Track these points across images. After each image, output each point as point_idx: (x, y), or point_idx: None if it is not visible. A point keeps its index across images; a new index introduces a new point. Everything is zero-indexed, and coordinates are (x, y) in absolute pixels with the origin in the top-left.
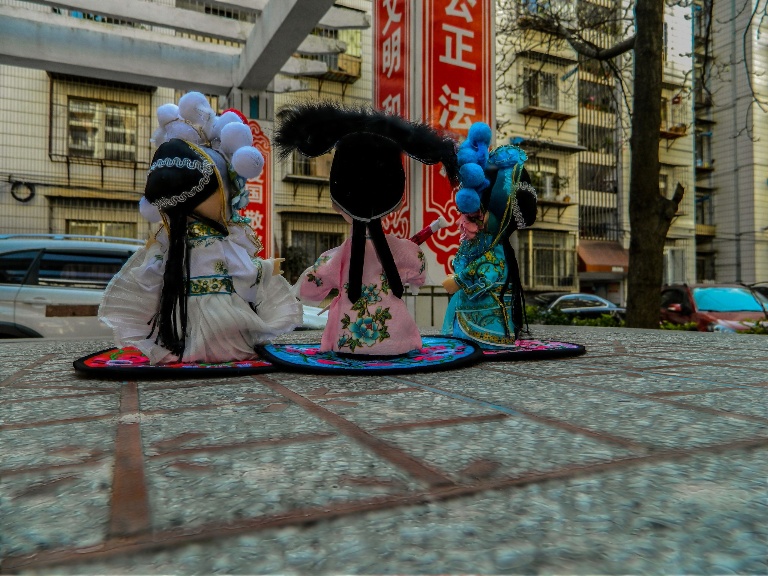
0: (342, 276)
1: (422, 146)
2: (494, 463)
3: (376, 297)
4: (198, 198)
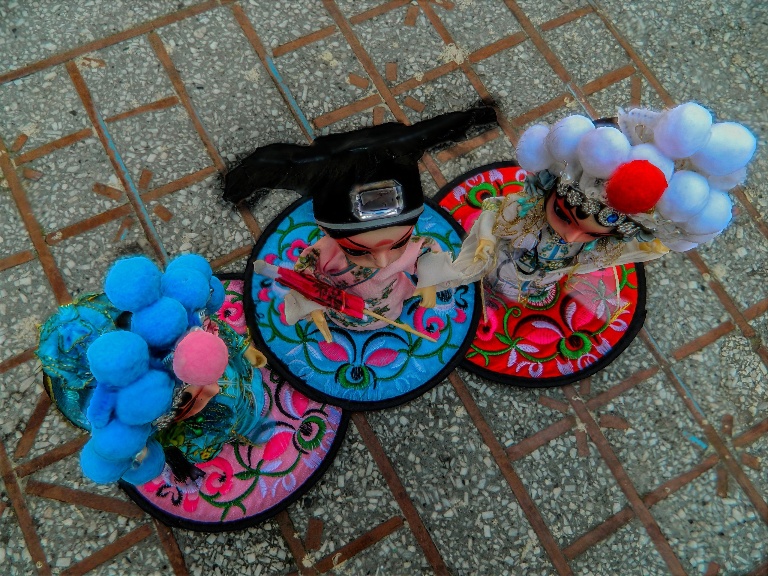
0: None
1: (282, 150)
2: None
3: None
4: None
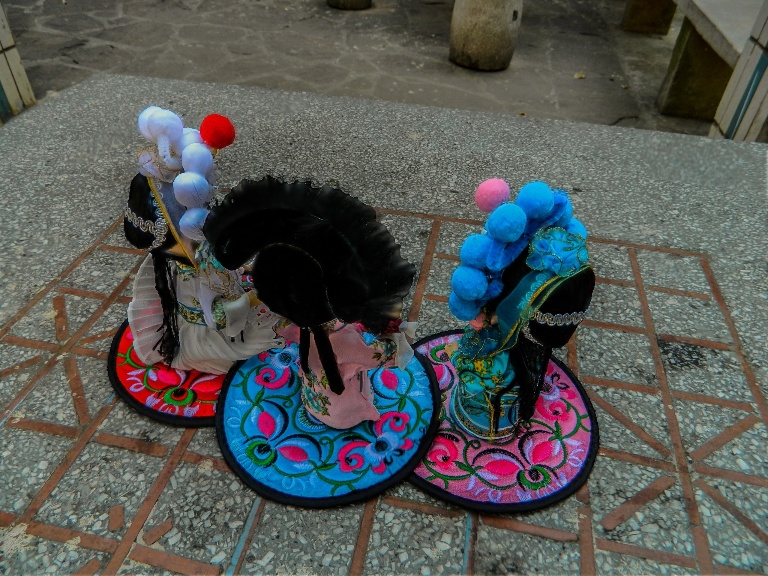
0: None
1: (348, 289)
2: None
3: (318, 383)
4: None
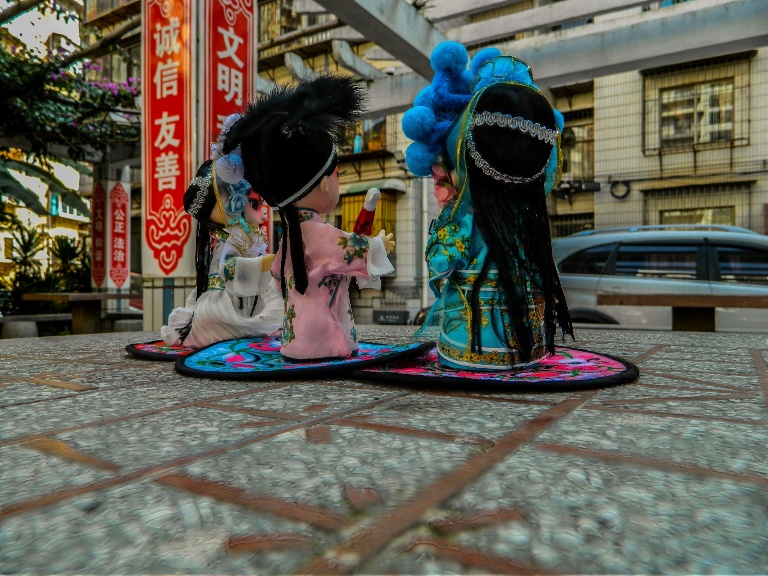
0: None
1: (300, 112)
2: None
3: None
4: (206, 208)
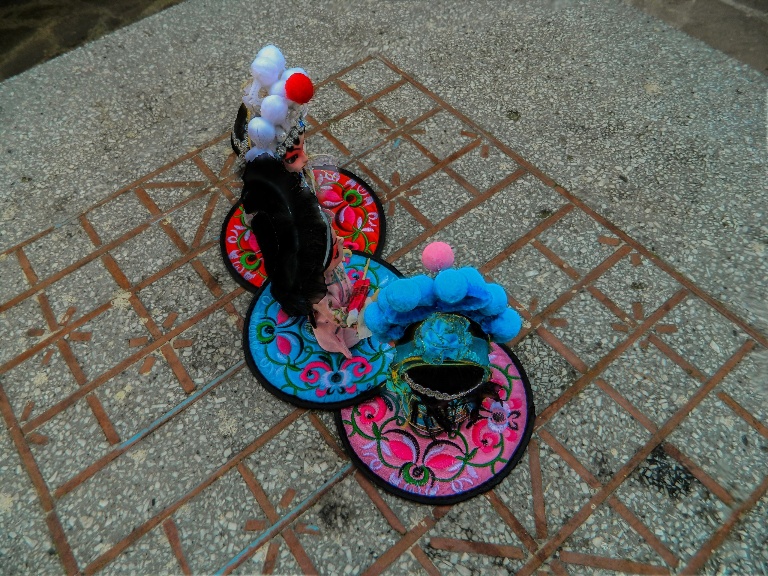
0: None
1: (282, 276)
2: (47, 442)
3: None
4: None
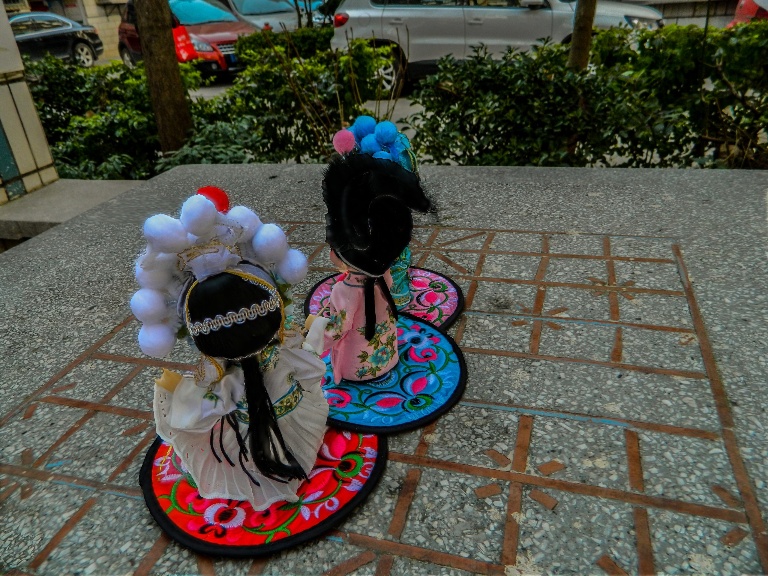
0: (353, 322)
1: (412, 195)
2: (714, 485)
3: (386, 329)
4: None
